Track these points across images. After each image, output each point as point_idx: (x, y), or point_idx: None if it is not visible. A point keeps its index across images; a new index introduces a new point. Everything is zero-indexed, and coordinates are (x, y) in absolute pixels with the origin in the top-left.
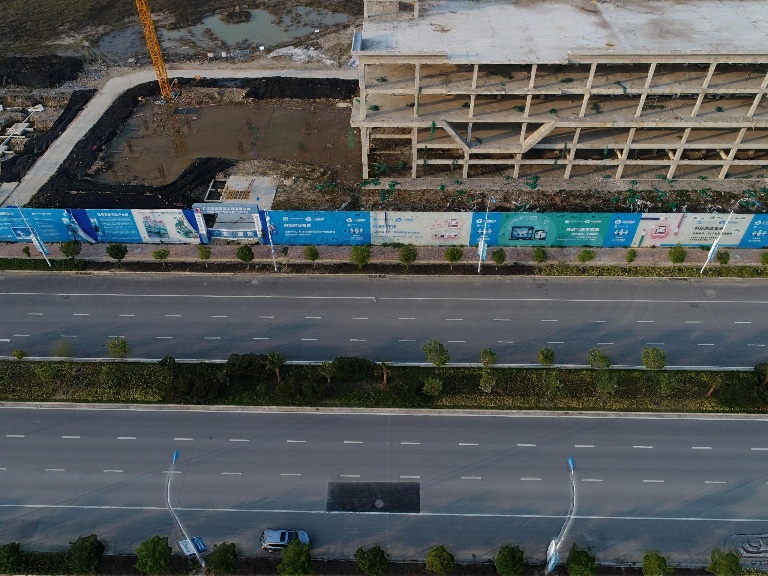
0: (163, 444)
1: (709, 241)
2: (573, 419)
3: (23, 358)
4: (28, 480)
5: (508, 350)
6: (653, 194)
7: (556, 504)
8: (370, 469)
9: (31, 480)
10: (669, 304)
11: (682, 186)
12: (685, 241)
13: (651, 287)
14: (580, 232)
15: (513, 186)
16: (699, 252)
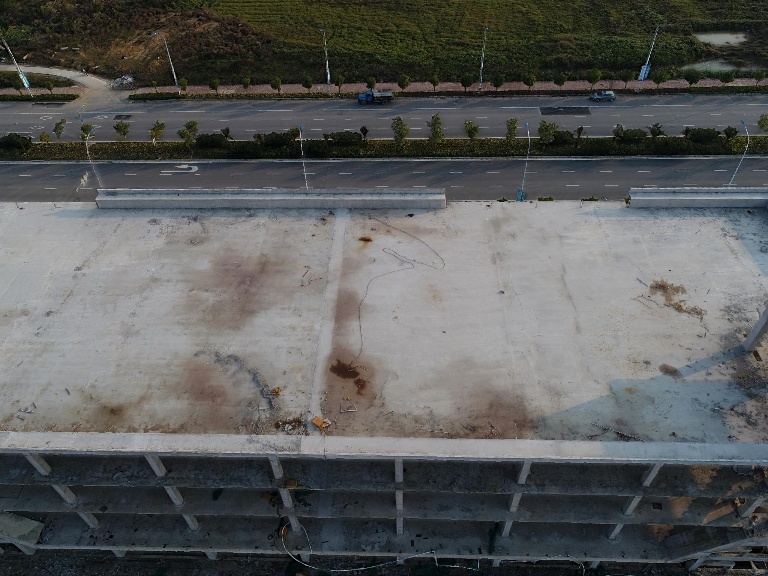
0: (698, 123)
1: None
2: (453, 137)
3: None
4: (760, 111)
5: (492, 167)
6: None
7: (470, 111)
8: (571, 118)
9: (758, 111)
10: None
11: None
12: None
13: None
14: None
15: None
16: None
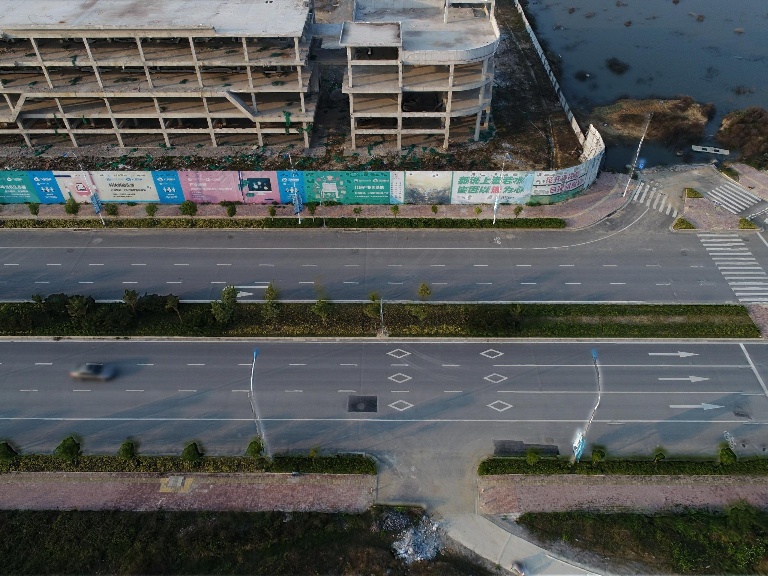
0: None
1: (132, 197)
2: None
3: None
4: None
5: None
6: (141, 160)
7: None
8: None
9: None
10: (49, 250)
11: (174, 153)
12: (111, 198)
13: (49, 236)
14: (11, 189)
15: (21, 153)
16: (123, 207)
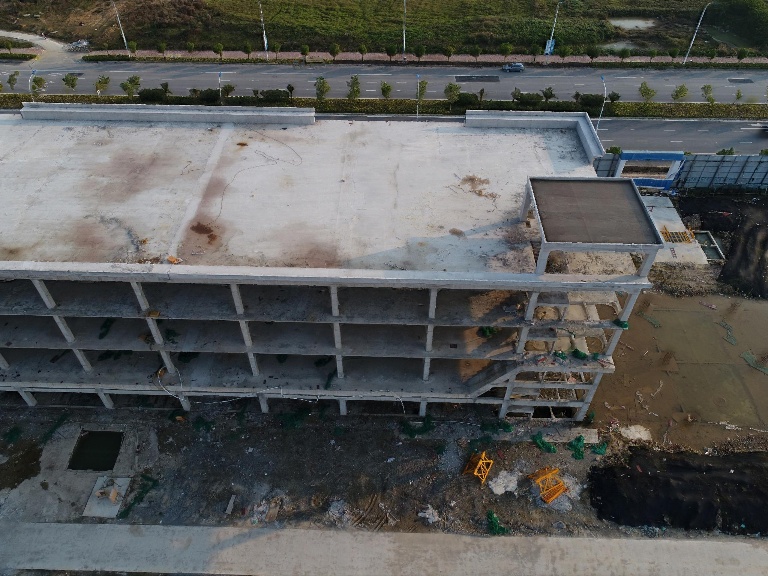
0: None
1: None
2: (373, 98)
3: (718, 120)
4: (649, 83)
5: None
6: None
7: (392, 77)
8: (481, 85)
9: (648, 83)
10: None
11: None
12: None
13: None
14: None
15: None
16: None
